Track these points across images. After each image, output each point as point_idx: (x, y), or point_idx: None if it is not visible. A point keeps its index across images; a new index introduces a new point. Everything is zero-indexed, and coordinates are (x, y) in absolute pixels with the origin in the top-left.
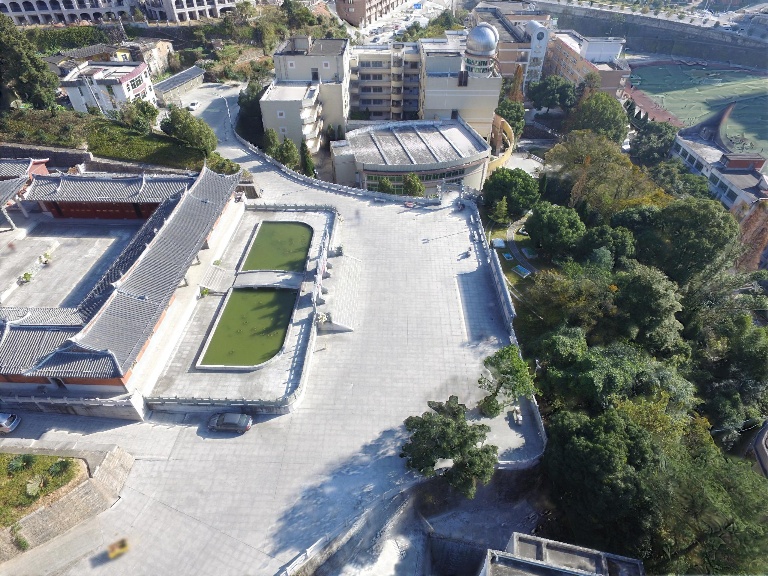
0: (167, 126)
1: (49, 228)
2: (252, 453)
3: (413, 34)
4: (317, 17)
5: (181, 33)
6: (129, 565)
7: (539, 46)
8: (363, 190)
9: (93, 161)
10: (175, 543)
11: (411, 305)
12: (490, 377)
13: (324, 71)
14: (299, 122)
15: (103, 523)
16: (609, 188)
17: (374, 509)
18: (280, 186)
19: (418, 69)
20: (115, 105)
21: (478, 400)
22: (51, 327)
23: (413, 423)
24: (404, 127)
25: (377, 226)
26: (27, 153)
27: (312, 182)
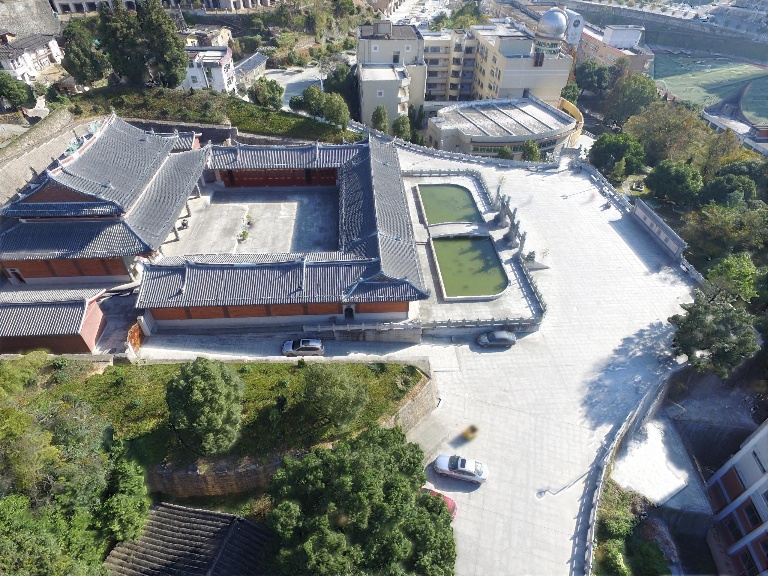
0: (298, 103)
1: (227, 196)
2: (527, 361)
3: (443, 24)
4: (356, 7)
5: (239, 21)
6: (483, 444)
7: (575, 33)
8: (486, 158)
9: (239, 136)
10: (510, 427)
11: (585, 246)
12: (683, 296)
13: (405, 54)
14: (396, 101)
15: (440, 418)
16: (699, 149)
17: (650, 393)
18: (405, 157)
19: (474, 54)
20: (211, 88)
21: (684, 312)
22: (343, 263)
23: (681, 319)
24: (484, 105)
25: (515, 187)
26: (174, 129)
27: (433, 153)
